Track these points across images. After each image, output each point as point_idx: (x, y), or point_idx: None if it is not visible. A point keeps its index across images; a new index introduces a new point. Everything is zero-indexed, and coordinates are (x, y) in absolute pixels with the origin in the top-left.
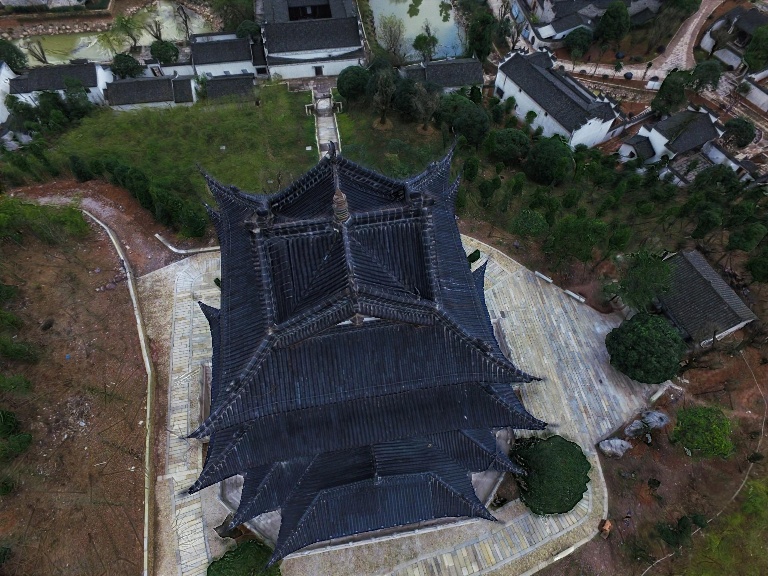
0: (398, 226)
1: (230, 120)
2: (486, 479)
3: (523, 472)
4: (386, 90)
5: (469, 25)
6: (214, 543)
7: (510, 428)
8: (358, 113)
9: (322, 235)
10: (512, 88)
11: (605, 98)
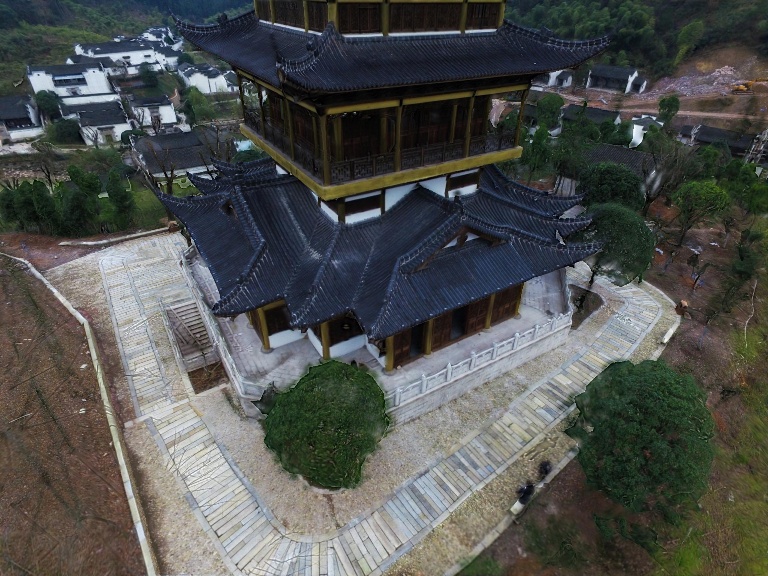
0: None
1: None
2: (552, 294)
3: None
4: None
5: None
6: (247, 464)
7: None
8: None
9: None
10: None
11: None
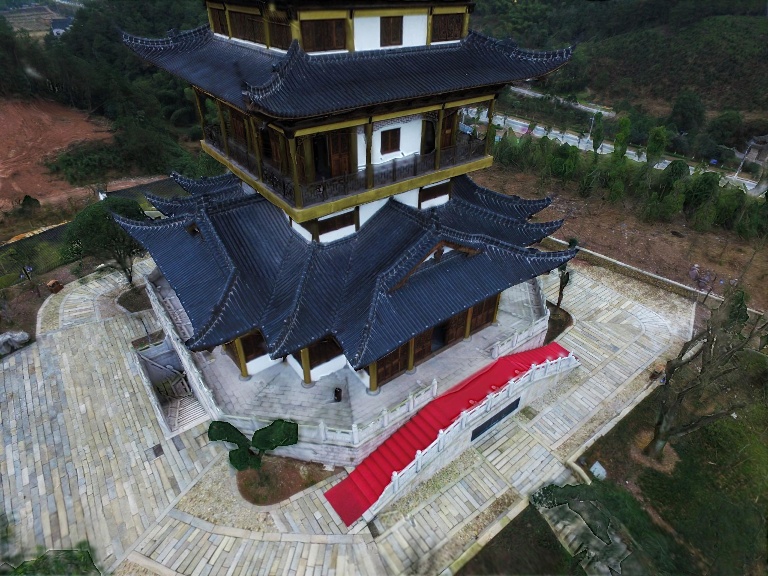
0: None
1: None
2: None
3: None
4: None
5: None
6: None
7: (156, 292)
8: None
9: None
10: None
11: None
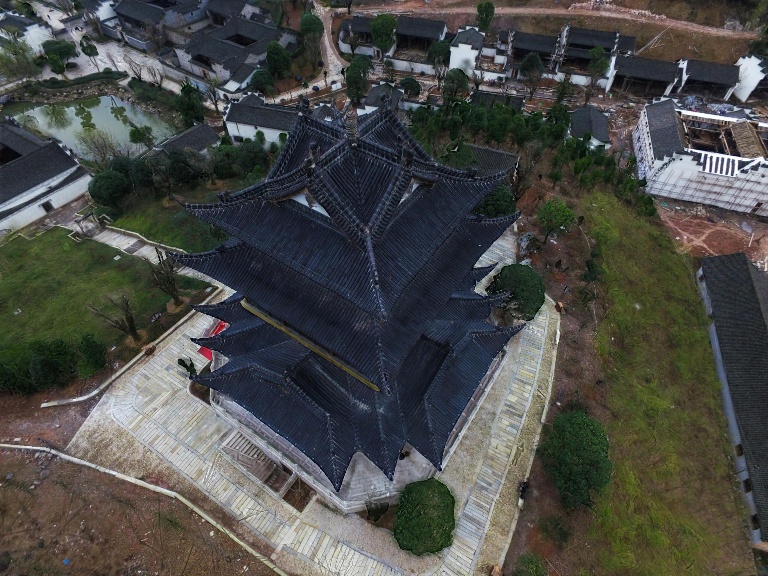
0: (378, 131)
1: (3, 283)
2: None
3: (508, 296)
4: (159, 169)
5: (160, 111)
6: (368, 546)
7: None
8: (139, 207)
9: (344, 157)
10: (247, 130)
11: (320, 103)
